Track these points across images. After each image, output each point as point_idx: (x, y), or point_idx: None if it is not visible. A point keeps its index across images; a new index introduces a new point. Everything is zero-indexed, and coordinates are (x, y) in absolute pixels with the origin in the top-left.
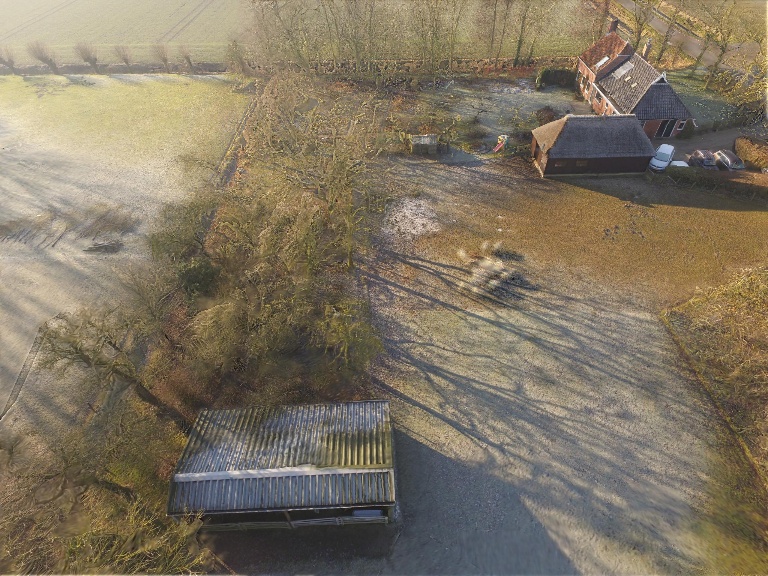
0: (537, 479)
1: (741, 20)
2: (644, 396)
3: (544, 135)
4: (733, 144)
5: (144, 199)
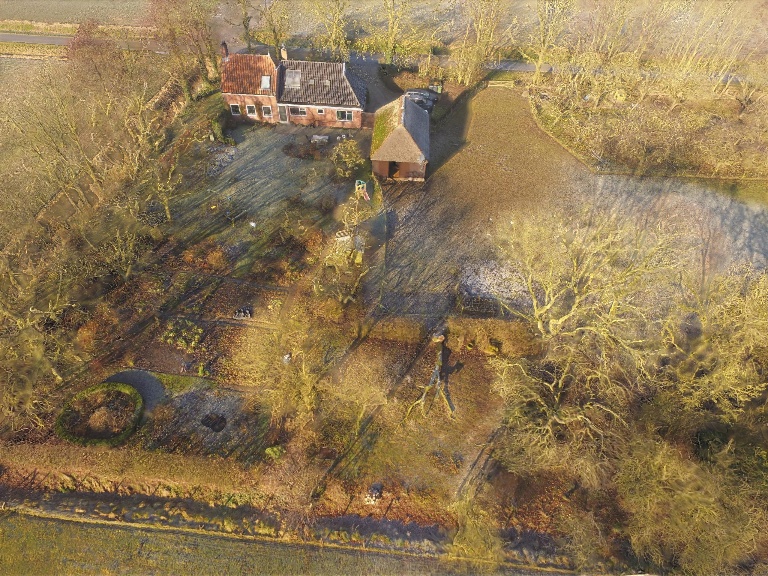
0: (763, 252)
1: (141, 12)
2: (672, 198)
3: (397, 152)
4: (394, 85)
5: None
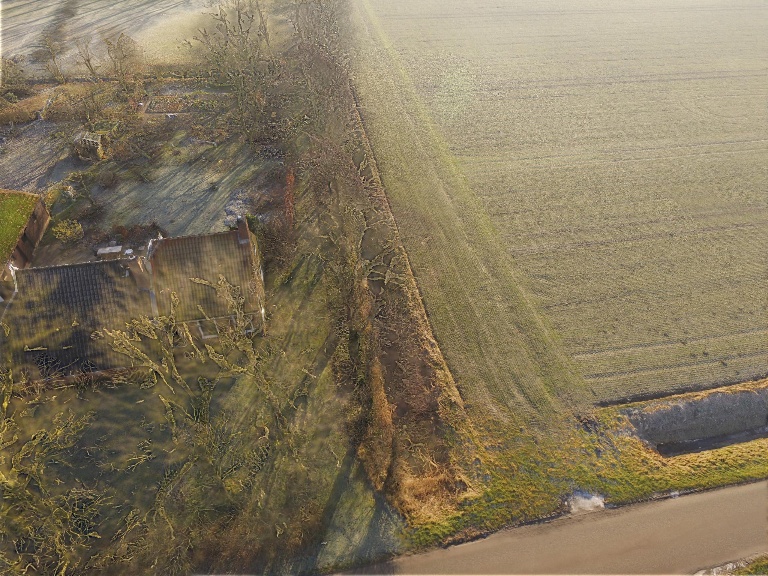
0: None
1: None
2: None
3: None
4: None
5: (72, 59)
